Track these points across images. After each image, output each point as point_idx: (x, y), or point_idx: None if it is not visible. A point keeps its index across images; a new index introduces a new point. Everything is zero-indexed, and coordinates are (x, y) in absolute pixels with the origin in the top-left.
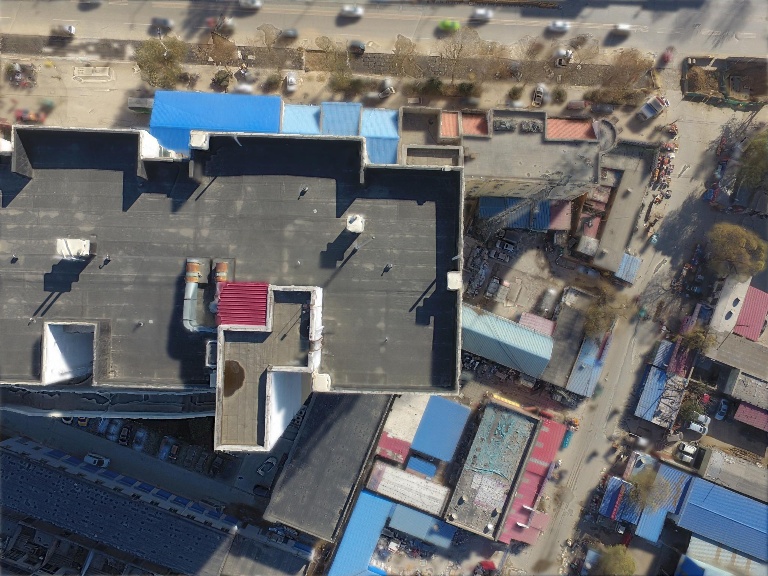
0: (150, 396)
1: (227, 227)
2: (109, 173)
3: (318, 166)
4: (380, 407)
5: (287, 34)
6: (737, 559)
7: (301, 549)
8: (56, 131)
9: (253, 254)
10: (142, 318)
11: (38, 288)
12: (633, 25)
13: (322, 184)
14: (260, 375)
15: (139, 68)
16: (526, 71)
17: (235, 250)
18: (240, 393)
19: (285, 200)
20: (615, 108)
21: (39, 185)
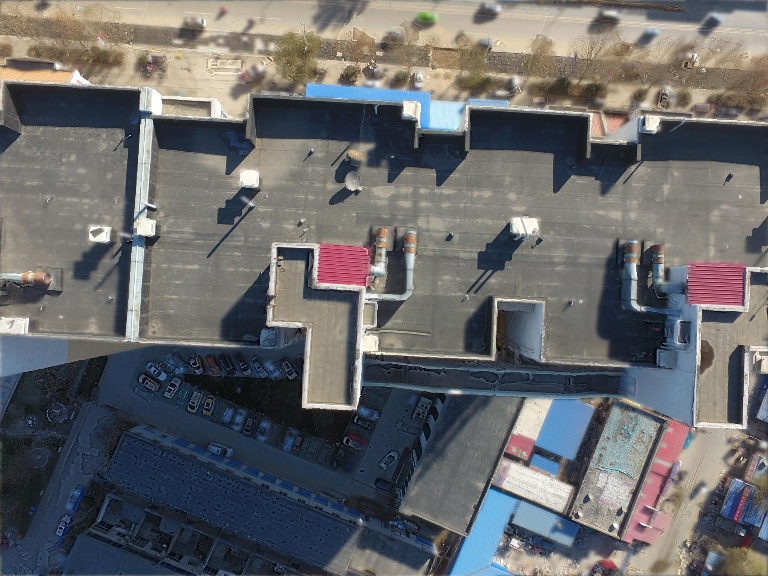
0: (535, 376)
1: (654, 210)
2: (540, 155)
3: (742, 153)
4: (515, 403)
5: None
6: None
7: (424, 543)
8: (508, 112)
9: (680, 237)
10: (572, 298)
11: (472, 266)
12: (758, 30)
13: (746, 171)
14: (730, 354)
15: (268, 62)
16: (657, 73)
17: (662, 233)
18: (710, 372)
19: (711, 185)
20: (741, 112)
21: (472, 165)
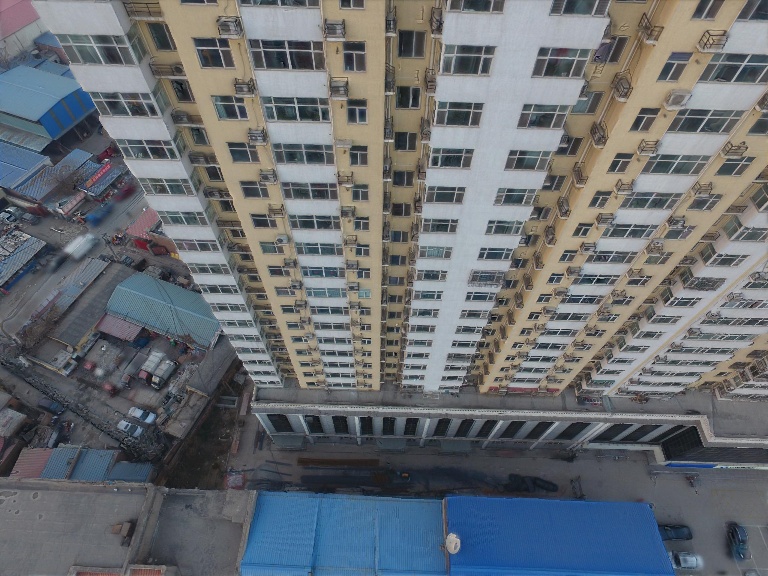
0: None
1: None
2: None
3: None
4: None
5: None
6: (7, 138)
7: None
8: None
9: None
10: None
11: None
12: None
13: None
14: None
15: None
16: None
17: None
18: None
19: None
20: None
21: None
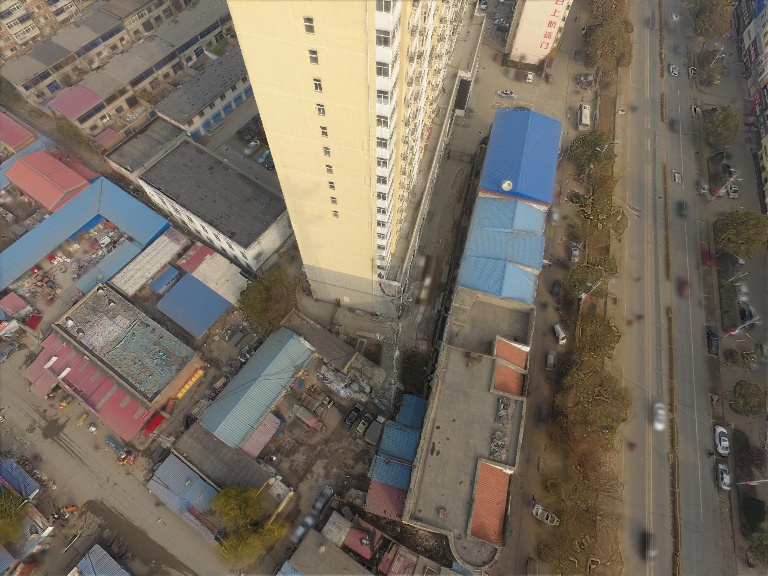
0: None
1: None
2: None
3: None
4: (237, 237)
5: (624, 258)
6: None
7: None
8: None
9: None
10: None
11: None
12: None
13: None
14: None
15: None
16: None
17: None
18: None
19: None
20: None
21: None
